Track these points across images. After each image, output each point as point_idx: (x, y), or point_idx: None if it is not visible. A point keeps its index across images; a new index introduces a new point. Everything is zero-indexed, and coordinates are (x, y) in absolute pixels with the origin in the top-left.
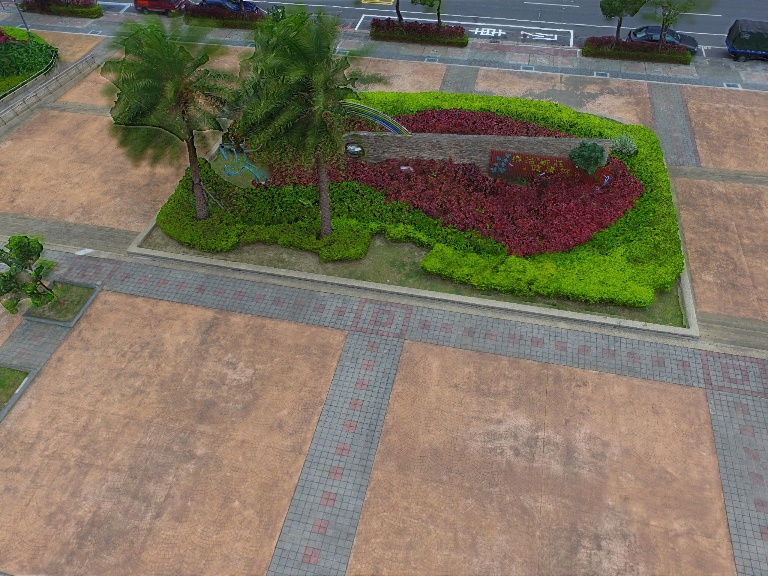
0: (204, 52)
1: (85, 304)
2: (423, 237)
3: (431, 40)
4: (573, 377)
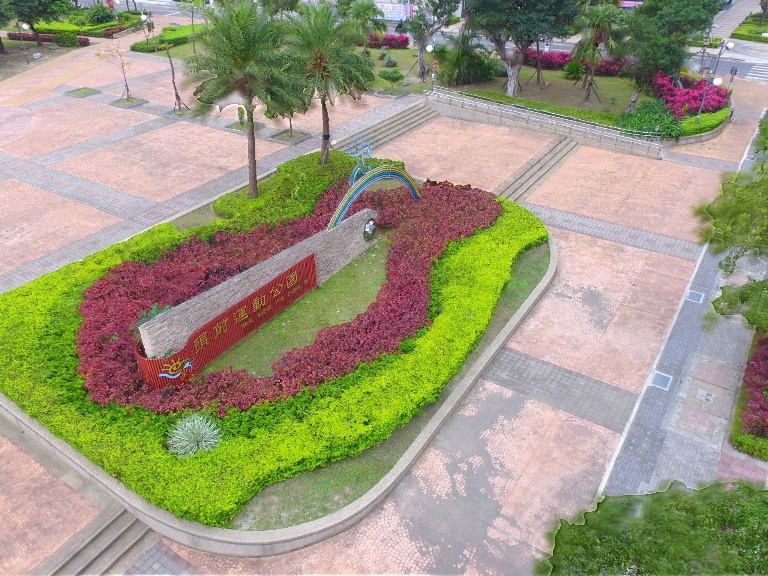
0: (696, 205)
1: (280, 140)
2: None
3: None
4: (0, 269)
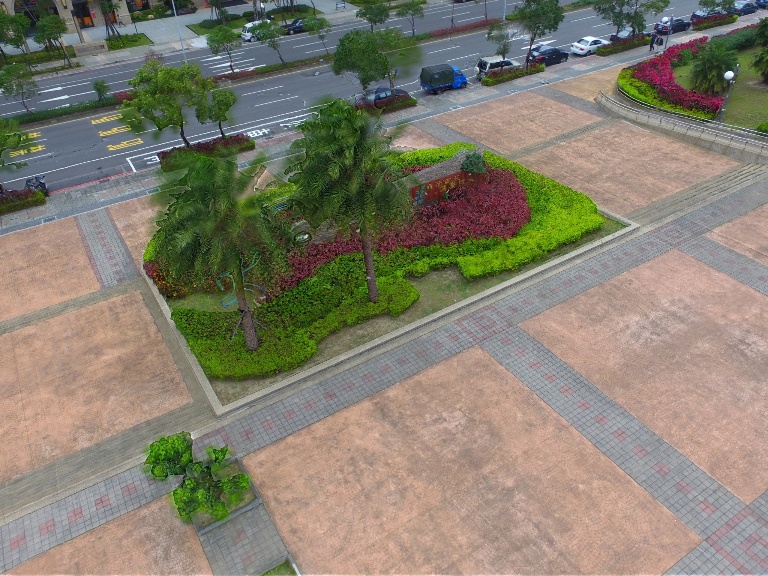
0: None
1: (248, 476)
2: (444, 260)
3: (224, 153)
4: (622, 282)
